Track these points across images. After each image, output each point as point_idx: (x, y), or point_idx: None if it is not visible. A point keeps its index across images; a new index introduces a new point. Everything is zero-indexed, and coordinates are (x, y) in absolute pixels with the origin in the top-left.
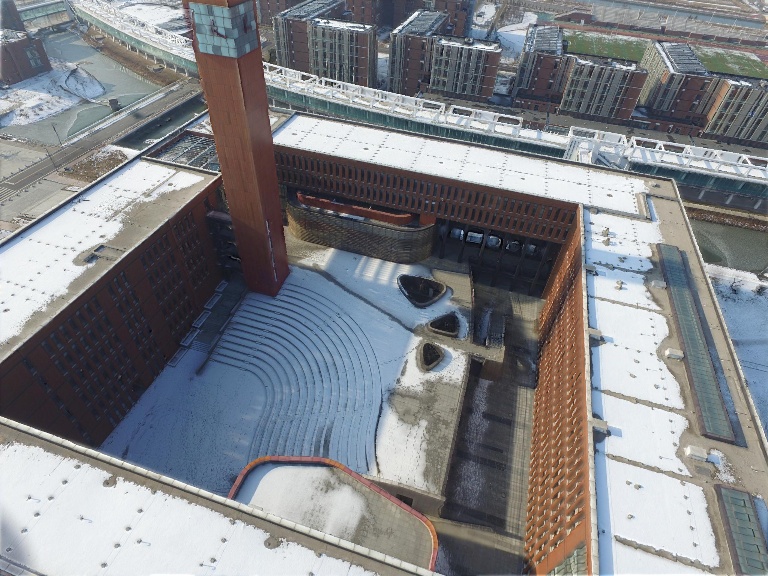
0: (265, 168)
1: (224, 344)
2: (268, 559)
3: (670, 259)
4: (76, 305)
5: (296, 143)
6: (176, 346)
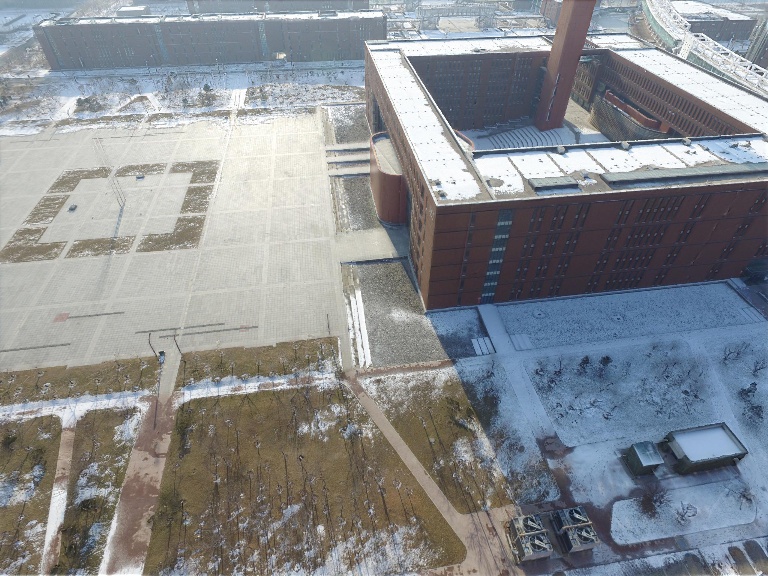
0: (574, 40)
1: (499, 136)
2: (422, 105)
3: (761, 165)
4: (456, 58)
5: (628, 56)
6: (482, 126)
